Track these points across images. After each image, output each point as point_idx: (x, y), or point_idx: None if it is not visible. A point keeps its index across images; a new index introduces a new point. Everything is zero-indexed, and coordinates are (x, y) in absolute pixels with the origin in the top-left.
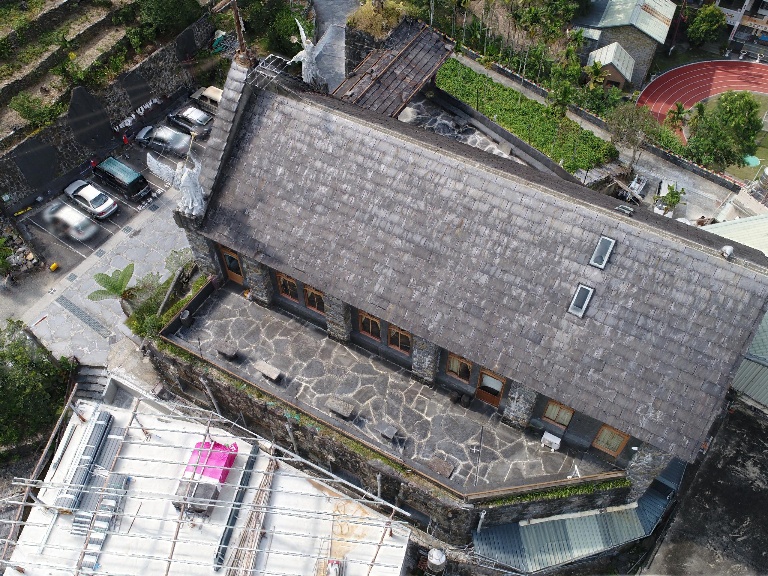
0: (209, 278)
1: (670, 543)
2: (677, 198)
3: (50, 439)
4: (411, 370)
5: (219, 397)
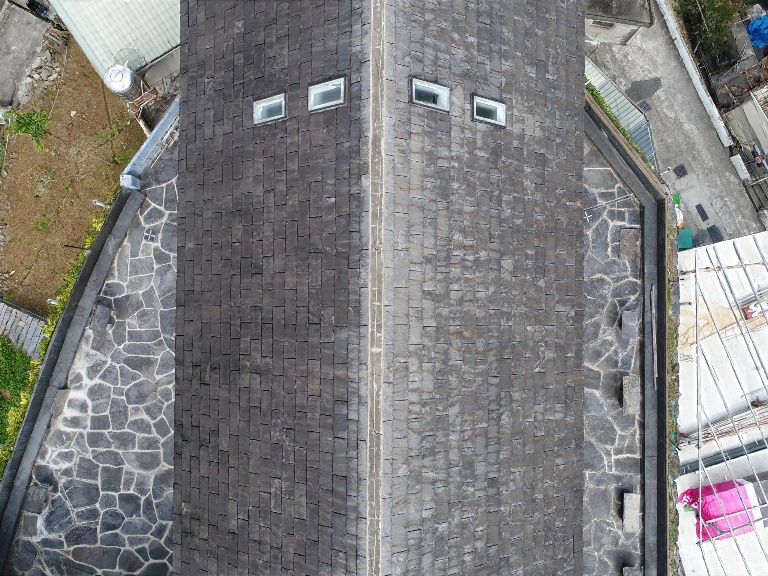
0: None
1: None
2: (30, 117)
3: None
4: None
5: None
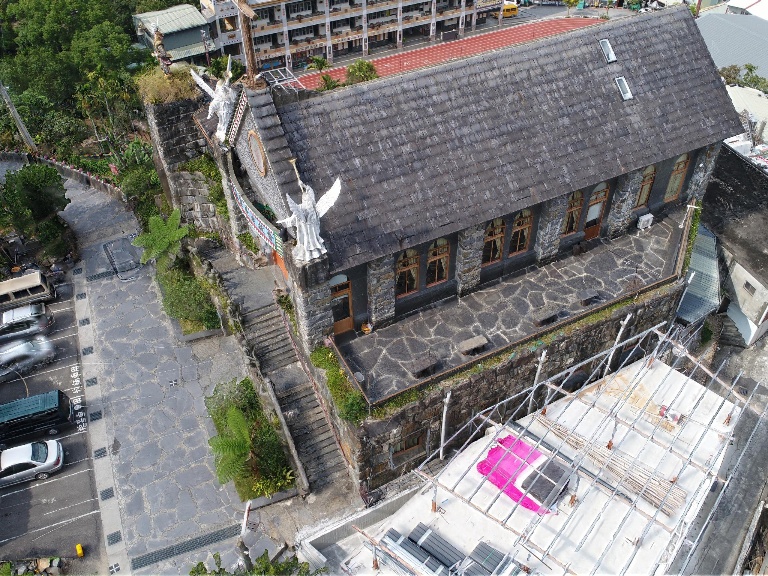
0: (329, 342)
1: (721, 235)
2: None
3: (419, 573)
4: (532, 264)
5: (451, 415)
